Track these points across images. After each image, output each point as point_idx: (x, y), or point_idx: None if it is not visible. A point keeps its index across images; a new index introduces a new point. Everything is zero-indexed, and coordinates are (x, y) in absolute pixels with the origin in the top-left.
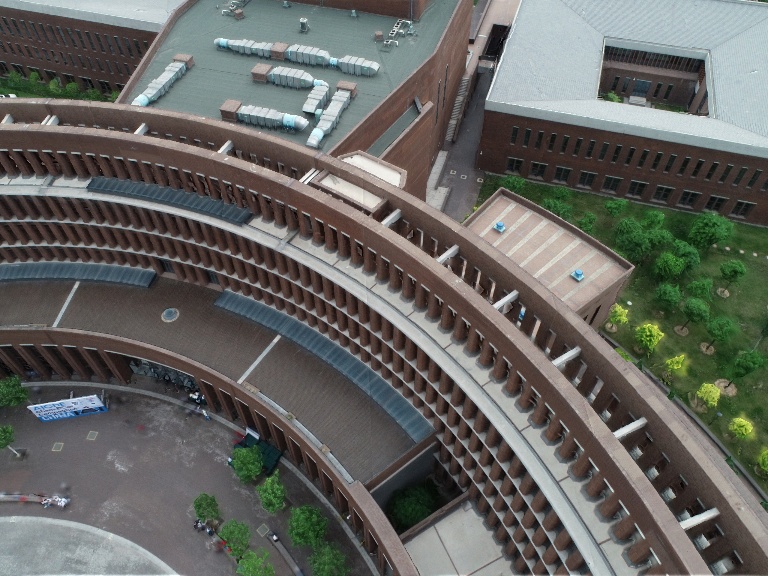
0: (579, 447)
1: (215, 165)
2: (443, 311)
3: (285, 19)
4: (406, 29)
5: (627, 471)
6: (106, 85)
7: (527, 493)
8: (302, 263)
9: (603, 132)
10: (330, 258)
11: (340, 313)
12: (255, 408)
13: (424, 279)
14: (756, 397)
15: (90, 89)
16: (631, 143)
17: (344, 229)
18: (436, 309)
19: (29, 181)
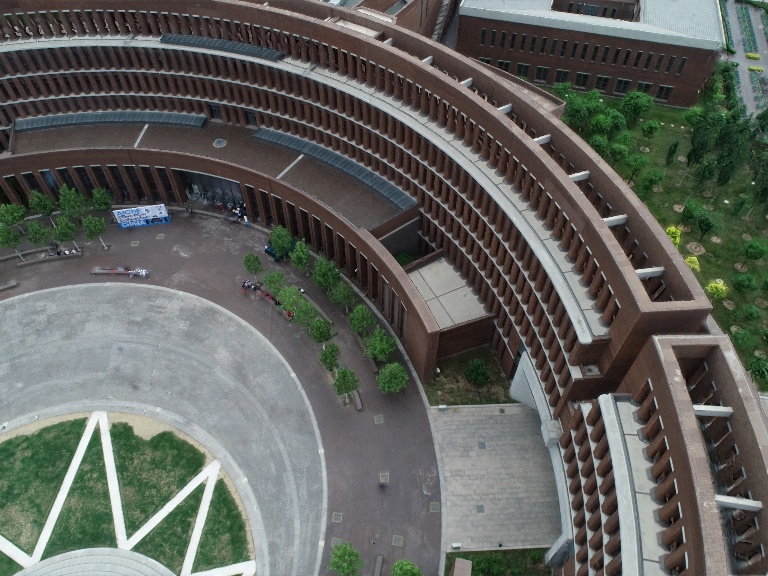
0: (508, 153)
1: (259, 13)
2: (422, 96)
3: None
4: None
5: (533, 148)
6: None
7: (478, 206)
8: (322, 82)
9: (552, 29)
10: (342, 79)
11: (349, 123)
12: (287, 198)
13: (409, 73)
14: (662, 212)
15: None
16: (574, 38)
17: (353, 50)
18: (417, 101)
19: (116, 38)
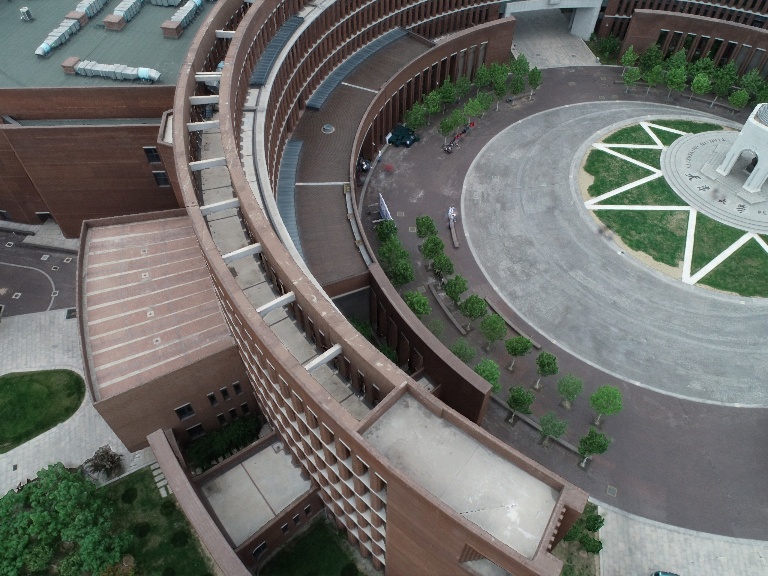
0: None
1: None
2: None
3: None
4: None
5: None
6: None
7: None
8: (334, 1)
9: None
10: None
11: None
12: None
13: None
14: None
15: None
16: None
17: None
18: None
19: (248, 120)
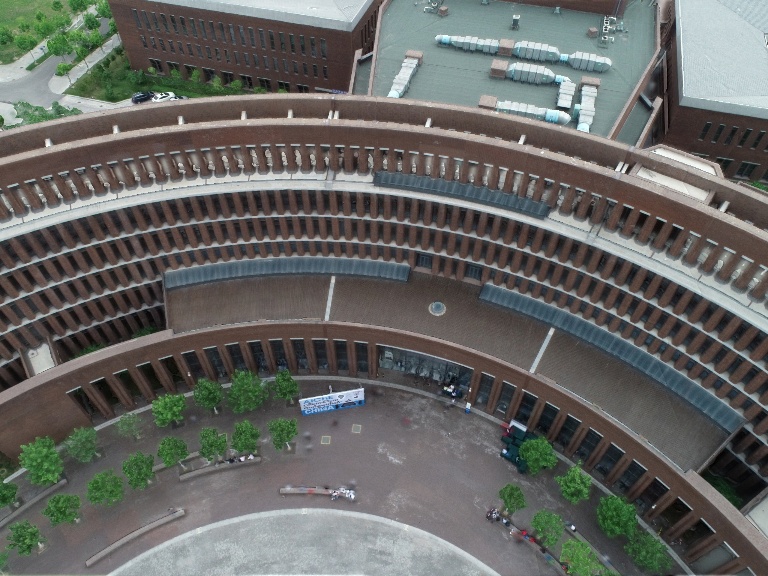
0: None
1: (529, 159)
2: None
3: (489, 16)
4: (613, 26)
5: None
6: (266, 83)
7: None
8: (618, 255)
9: None
10: (645, 250)
11: (645, 305)
12: (549, 400)
13: None
14: None
15: (248, 87)
16: None
17: (679, 221)
18: None
19: (310, 176)
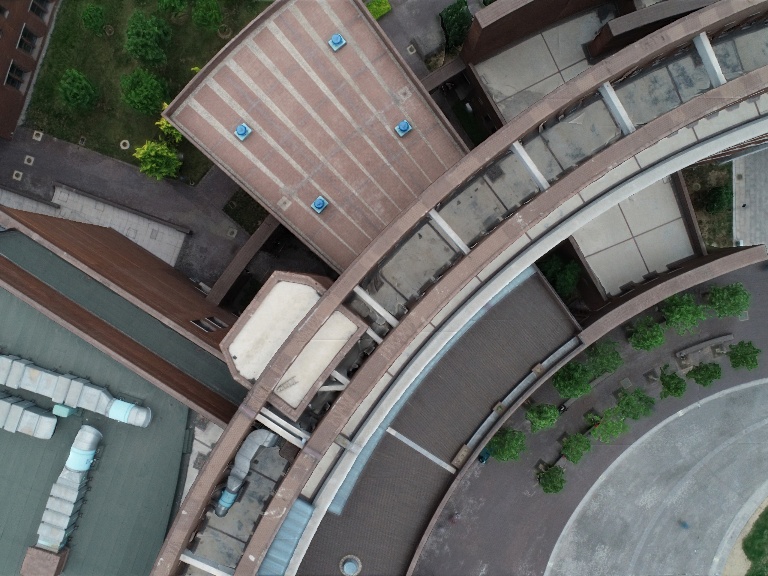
0: None
1: None
2: None
3: None
4: None
5: None
6: None
7: None
8: None
9: None
10: None
11: None
12: None
13: None
14: None
15: None
16: None
17: None
18: None
19: None
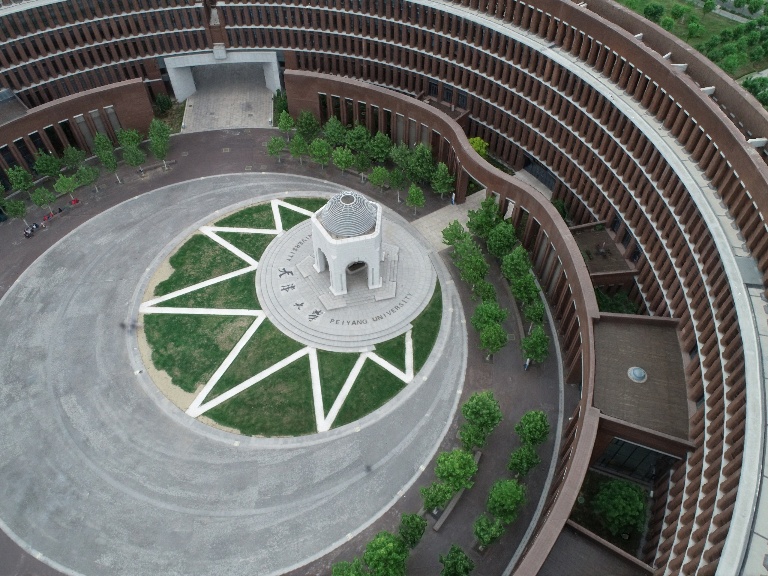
0: None
1: None
2: None
3: None
4: None
5: None
6: None
7: None
8: None
9: None
10: None
11: None
12: None
13: None
14: None
15: None
16: None
17: None
18: None
19: None
